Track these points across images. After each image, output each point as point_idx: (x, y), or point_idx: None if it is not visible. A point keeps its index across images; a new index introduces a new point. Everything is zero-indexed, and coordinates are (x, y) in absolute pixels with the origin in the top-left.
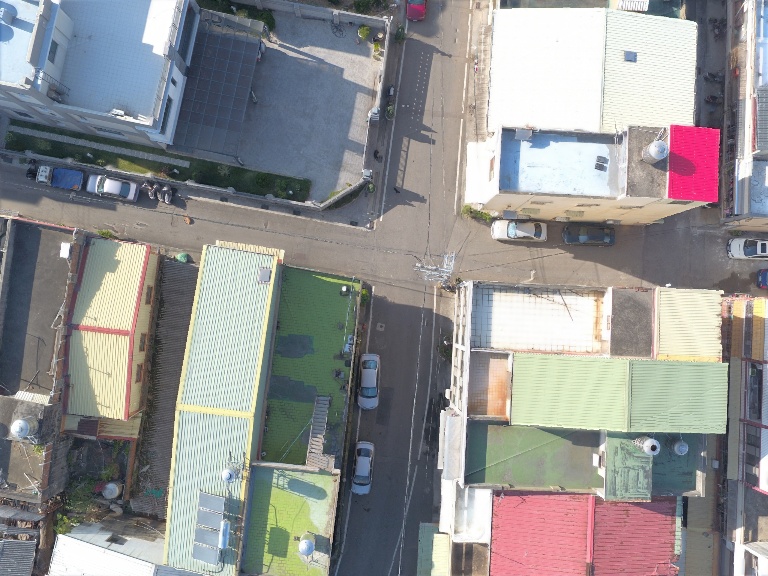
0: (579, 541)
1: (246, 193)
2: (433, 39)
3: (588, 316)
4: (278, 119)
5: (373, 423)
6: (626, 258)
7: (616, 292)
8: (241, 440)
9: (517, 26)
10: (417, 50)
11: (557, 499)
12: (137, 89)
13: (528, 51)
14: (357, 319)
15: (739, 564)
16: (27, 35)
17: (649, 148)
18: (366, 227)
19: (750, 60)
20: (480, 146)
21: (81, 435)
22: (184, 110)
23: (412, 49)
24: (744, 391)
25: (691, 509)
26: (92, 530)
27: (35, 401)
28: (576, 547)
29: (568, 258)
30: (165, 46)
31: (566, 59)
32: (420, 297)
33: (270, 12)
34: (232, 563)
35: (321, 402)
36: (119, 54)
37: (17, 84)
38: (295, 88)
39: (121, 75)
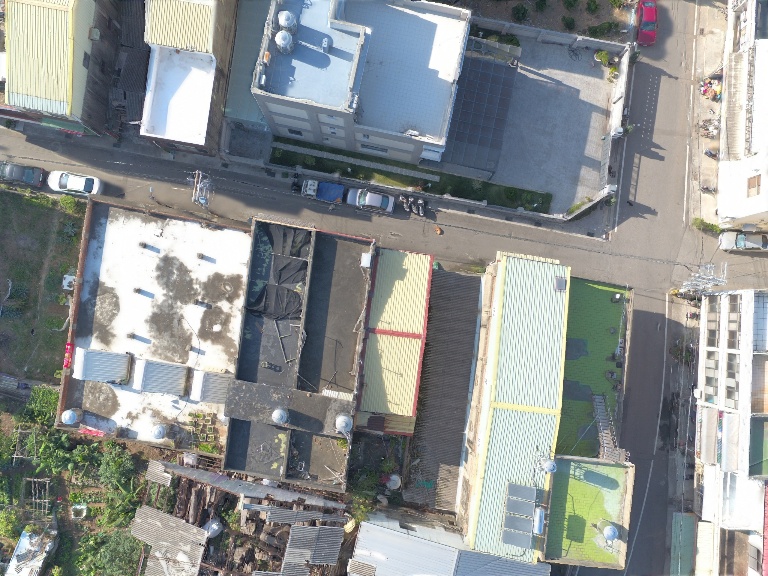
0: None
1: (499, 206)
2: (661, 62)
3: None
4: (520, 137)
5: None
6: None
7: None
8: (548, 435)
9: None
10: (646, 73)
11: None
12: (425, 111)
13: None
14: (631, 324)
15: None
16: (343, 62)
17: None
18: (602, 238)
19: None
20: (732, 164)
21: (370, 430)
22: (450, 129)
23: (641, 72)
24: None
25: None
26: (382, 518)
27: None
28: None
29: None
30: (456, 72)
31: None
32: (653, 303)
33: None
34: (533, 548)
35: (597, 400)
36: (408, 79)
37: (342, 108)
38: (535, 108)
39: (410, 98)
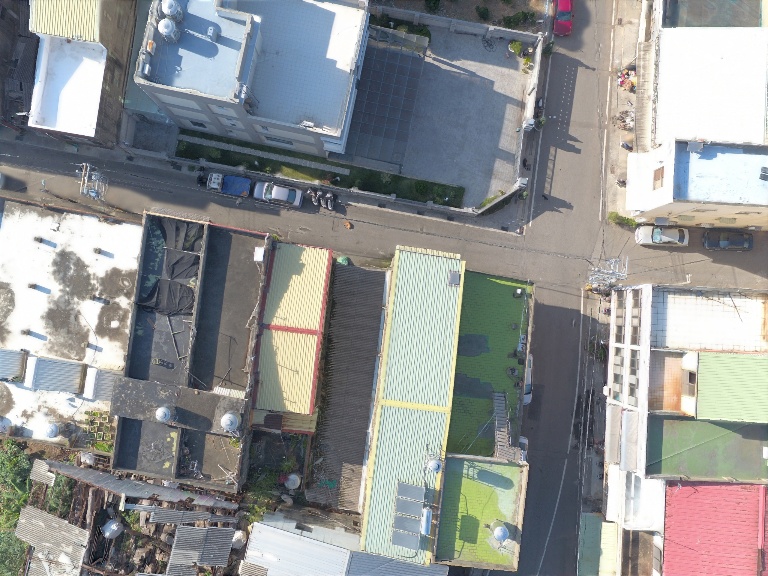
0: (751, 529)
1: (408, 200)
2: (578, 53)
3: (756, 317)
4: (433, 129)
5: (525, 418)
6: (762, 262)
7: None
8: (438, 433)
9: (683, 44)
10: (563, 64)
11: (729, 489)
12: (322, 102)
13: (694, 68)
14: (532, 320)
15: None
16: (231, 52)
17: None
18: (516, 232)
19: None
20: (640, 156)
21: (267, 429)
22: (354, 121)
23: (558, 63)
24: None
25: None
26: (278, 519)
27: (232, 396)
28: (748, 534)
29: (707, 262)
30: (352, 62)
31: (731, 75)
32: (568, 299)
33: None
34: (425, 549)
35: (497, 398)
36: (305, 69)
37: (227, 98)
38: (448, 100)
39: (307, 89)
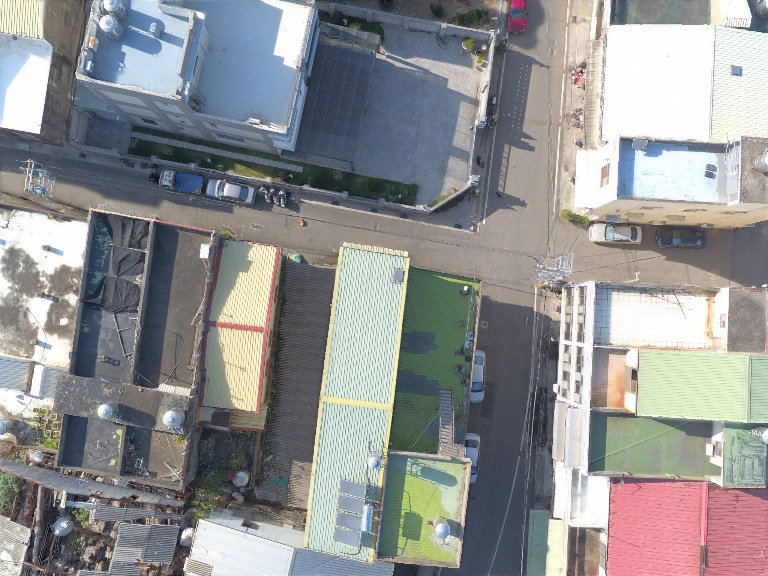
0: (694, 525)
1: (360, 197)
2: (532, 51)
3: (700, 315)
4: (386, 127)
5: (478, 416)
6: (715, 260)
7: (732, 292)
8: (380, 430)
9: (630, 41)
10: (517, 61)
11: (672, 486)
12: (269, 99)
13: (640, 65)
14: (478, 317)
15: None
16: (175, 48)
17: (765, 158)
18: (470, 230)
19: None
20: (589, 154)
21: (214, 426)
22: (305, 118)
23: (512, 60)
24: None
25: None
26: (225, 516)
27: None
28: (691, 531)
29: (661, 260)
30: (298, 59)
31: (677, 73)
32: (521, 296)
33: None
34: (369, 546)
35: (444, 395)
36: (252, 66)
37: (169, 95)
38: (402, 97)
39: (254, 86)
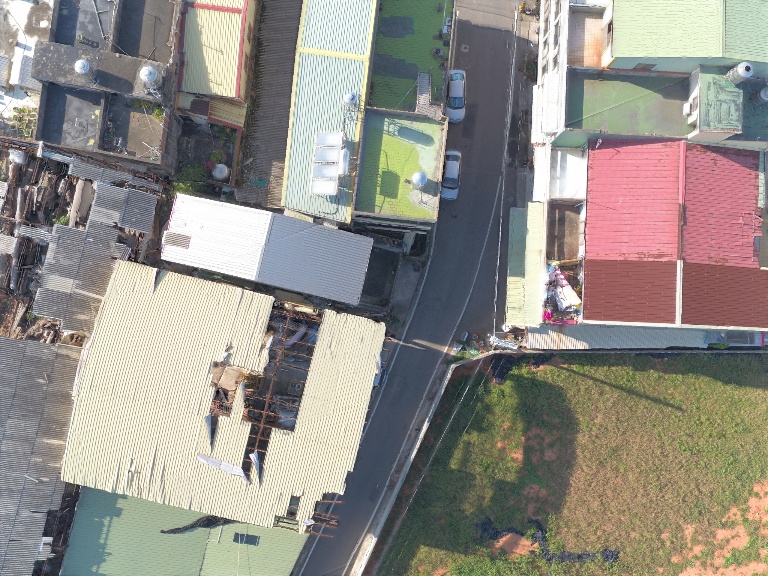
0: (672, 184)
1: None
2: None
3: None
4: None
5: (459, 137)
6: None
7: None
8: (357, 82)
9: None
10: None
11: (650, 147)
12: None
13: None
14: None
15: None
16: None
17: None
18: None
19: None
20: None
21: (193, 114)
22: None
23: None
24: None
25: None
26: None
27: None
28: (669, 190)
29: None
30: None
31: None
32: (502, 21)
33: None
34: (346, 205)
35: (422, 76)
36: None
37: None
38: None
39: None
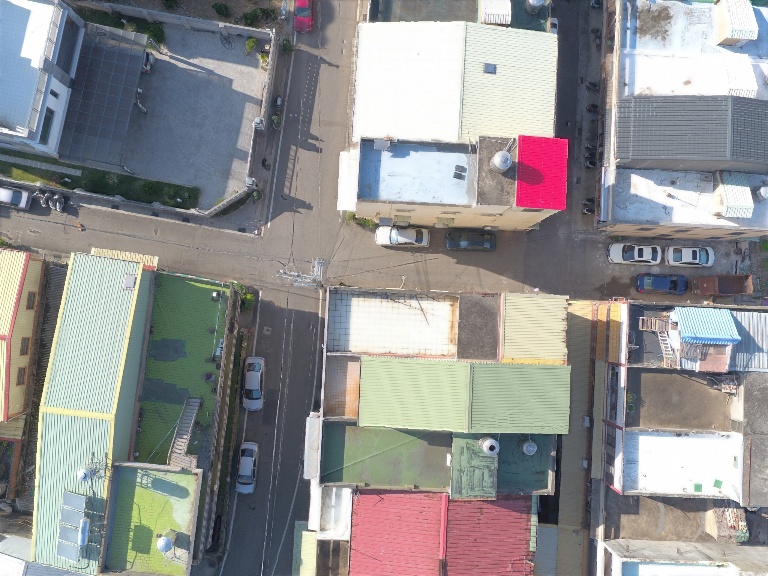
0: (432, 538)
1: (133, 201)
2: None
3: (444, 320)
4: (168, 129)
5: (259, 424)
6: (508, 263)
7: (463, 297)
8: (103, 441)
9: (381, 39)
10: (305, 61)
11: (412, 498)
12: (15, 101)
13: (391, 63)
14: (226, 323)
15: (600, 561)
16: None
17: (493, 158)
18: (254, 233)
19: (615, 71)
20: None
21: None
22: (69, 121)
23: (300, 60)
24: (606, 393)
25: (562, 507)
26: None
27: None
28: (430, 544)
29: (451, 263)
30: (40, 60)
31: (427, 71)
32: (306, 301)
33: (161, 25)
34: (97, 560)
35: (192, 404)
36: None
37: None
38: (185, 98)
39: None
